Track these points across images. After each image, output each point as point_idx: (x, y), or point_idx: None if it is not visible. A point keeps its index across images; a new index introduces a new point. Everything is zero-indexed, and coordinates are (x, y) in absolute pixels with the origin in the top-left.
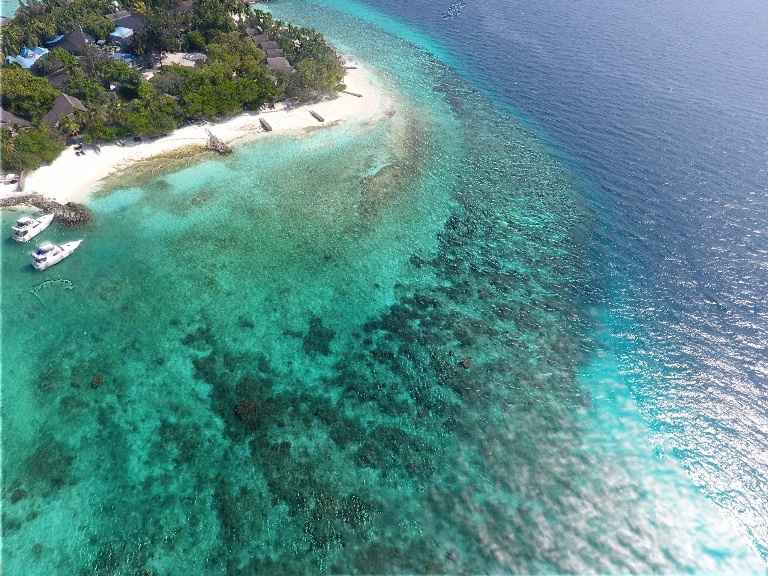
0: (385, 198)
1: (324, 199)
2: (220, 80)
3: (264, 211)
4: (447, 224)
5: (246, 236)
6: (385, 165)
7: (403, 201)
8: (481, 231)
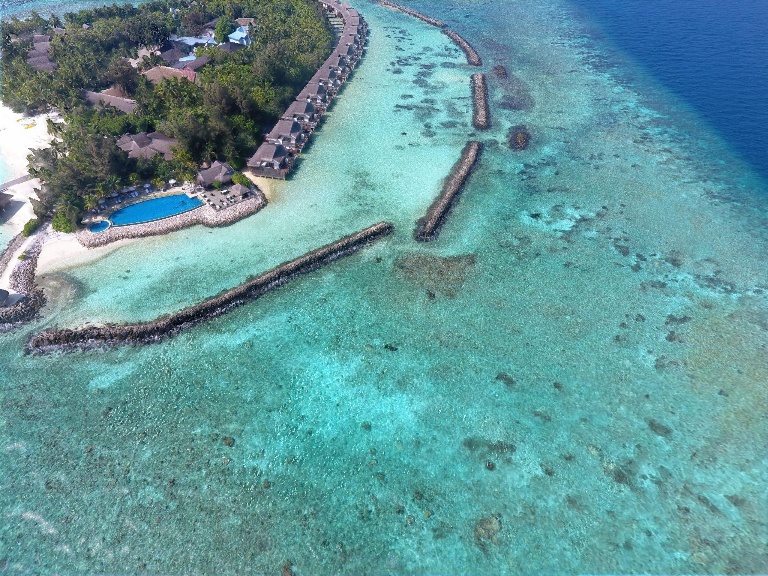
0: (44, 8)
1: (77, 8)
2: (104, 9)
3: (109, 6)
4: (24, 3)
5: (121, 2)
6: (27, 17)
7: (36, 8)
8: (10, 2)
